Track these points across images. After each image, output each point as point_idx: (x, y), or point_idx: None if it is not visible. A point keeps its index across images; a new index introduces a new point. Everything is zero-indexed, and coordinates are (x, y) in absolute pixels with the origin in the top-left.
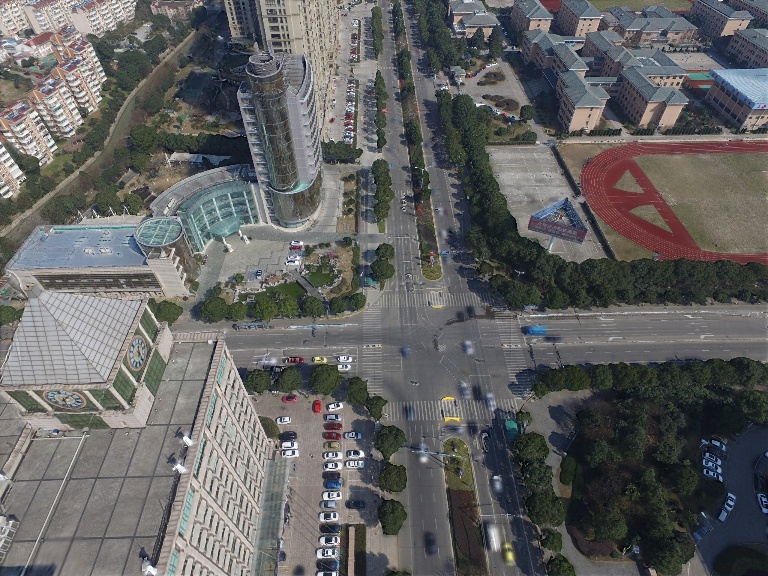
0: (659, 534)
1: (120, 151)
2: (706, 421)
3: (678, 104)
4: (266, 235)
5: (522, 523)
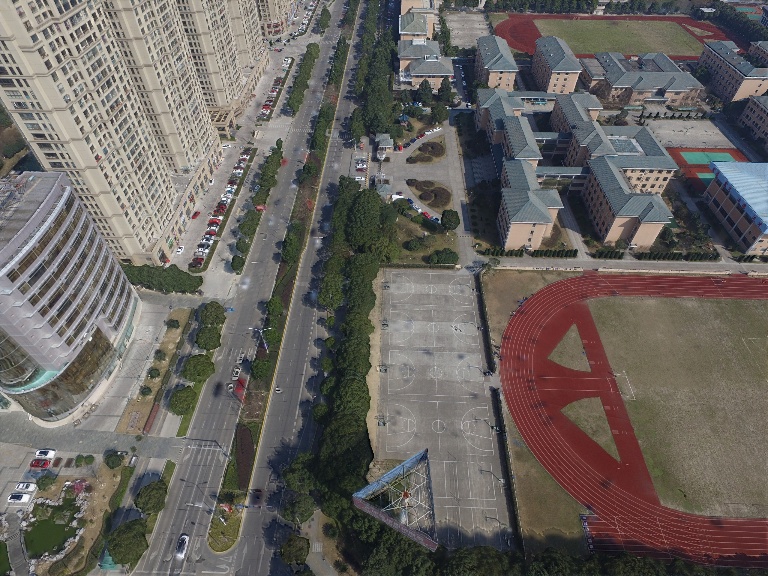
0: None
1: None
2: None
3: (657, 222)
4: (10, 432)
5: None
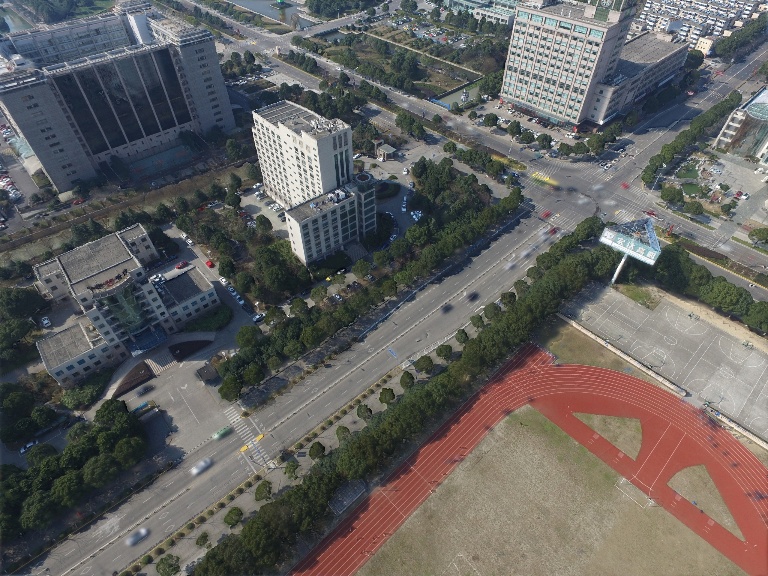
0: None
1: None
2: None
3: None
4: None
5: None
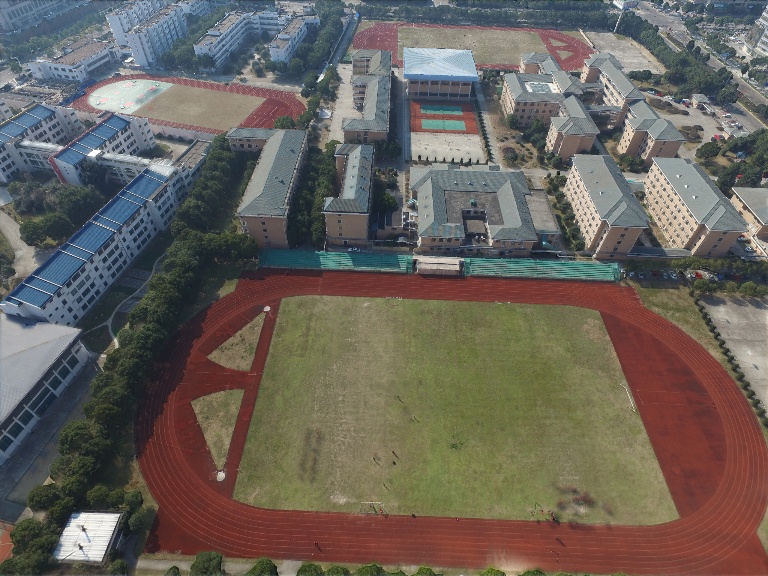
0: None
1: None
2: None
3: None
4: None
5: None
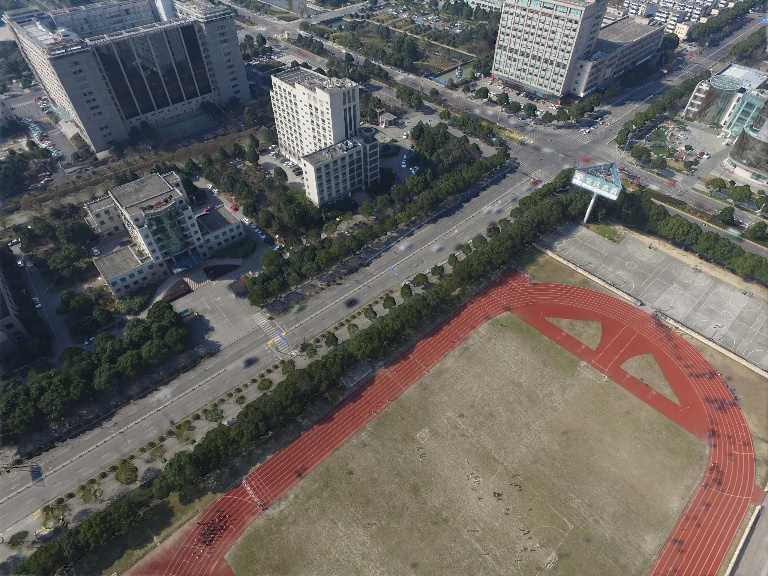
0: None
1: None
2: None
3: None
4: None
5: None
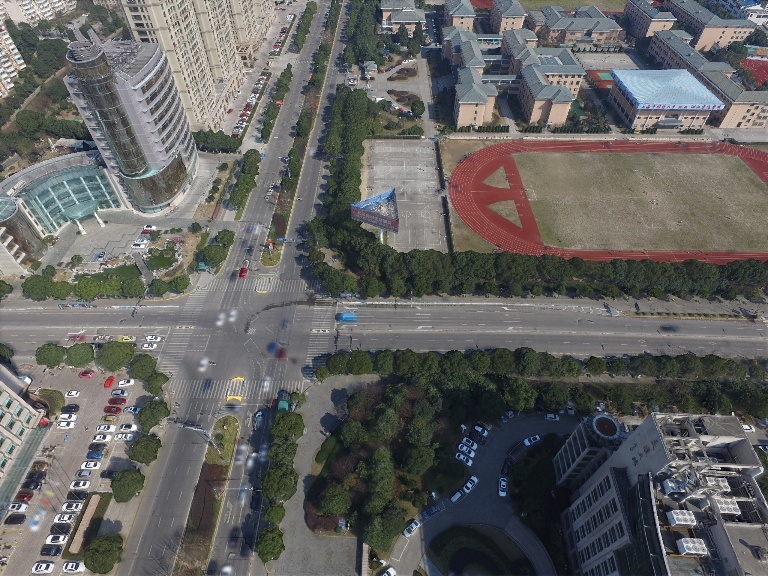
0: (370, 510)
1: (6, 135)
2: (473, 407)
3: (563, 102)
4: (124, 219)
5: (262, 497)
